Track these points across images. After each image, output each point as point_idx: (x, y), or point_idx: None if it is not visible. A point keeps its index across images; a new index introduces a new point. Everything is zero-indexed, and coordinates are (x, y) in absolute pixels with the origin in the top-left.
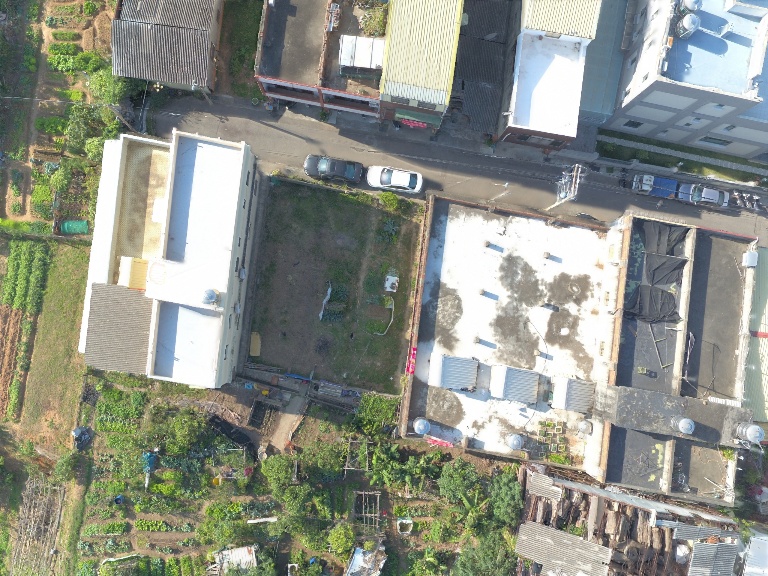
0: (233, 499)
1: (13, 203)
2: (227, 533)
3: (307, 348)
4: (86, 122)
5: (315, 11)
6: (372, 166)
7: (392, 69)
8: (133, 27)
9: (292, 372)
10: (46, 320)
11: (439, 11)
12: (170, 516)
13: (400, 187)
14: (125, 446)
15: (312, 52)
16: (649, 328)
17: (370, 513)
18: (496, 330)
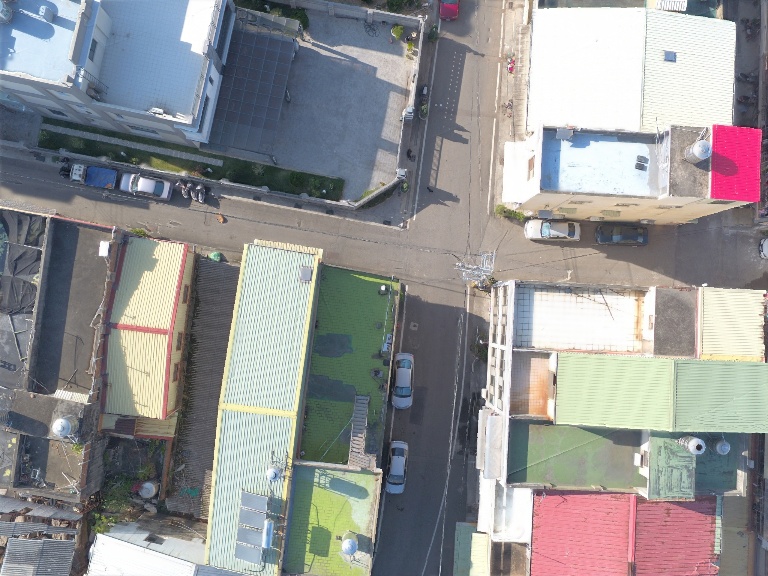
0: None
1: None
2: None
3: None
4: None
5: None
6: None
7: None
8: None
9: None
10: None
11: None
12: None
13: None
14: None
15: None
16: (9, 320)
17: None
18: None
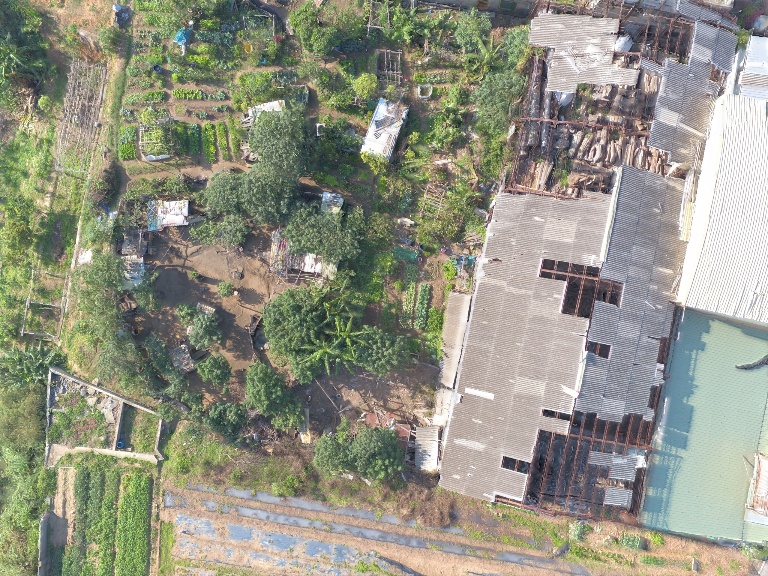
0: (264, 69)
1: None
2: (259, 81)
3: None
4: None
5: None
6: None
7: None
8: None
9: None
10: None
11: None
12: (205, 86)
13: None
14: (163, 3)
15: None
16: None
17: (392, 70)
18: None
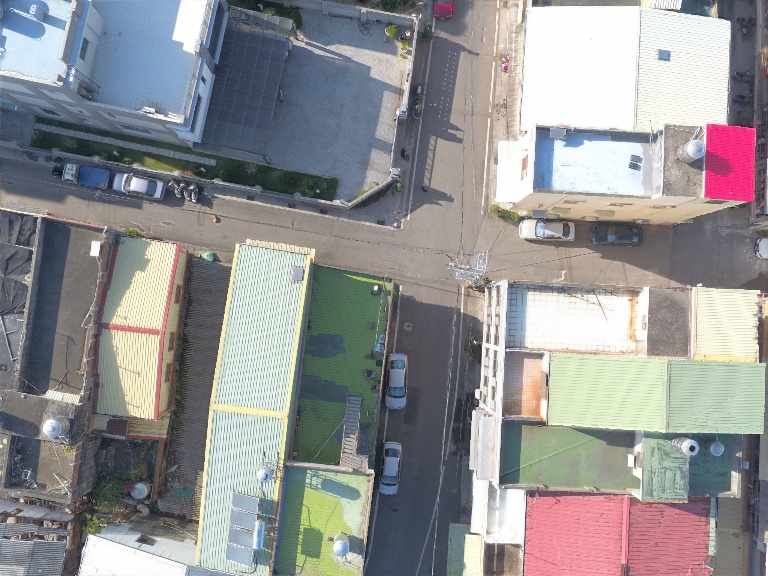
0: None
1: None
2: None
3: None
4: None
5: None
6: None
7: None
8: None
9: None
10: None
11: None
12: None
13: None
14: None
15: None
16: (0, 320)
17: None
18: None
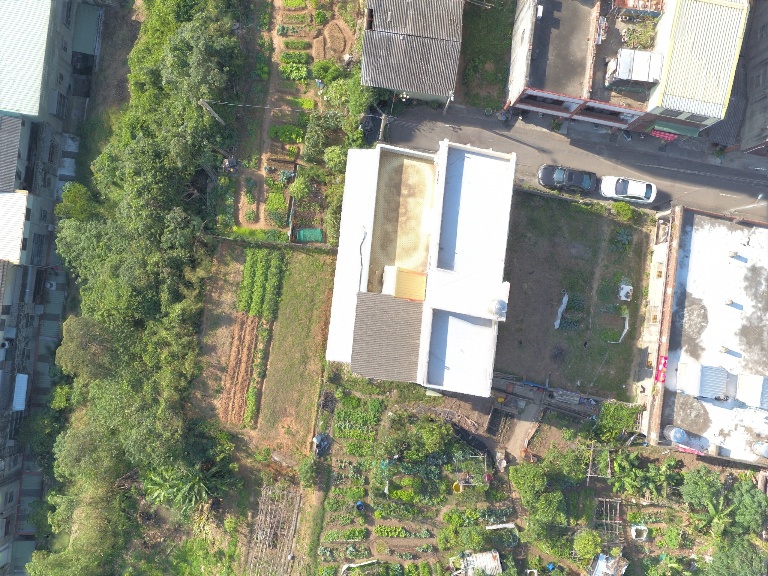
0: None
1: (247, 211)
2: (476, 539)
3: (542, 356)
4: (322, 131)
5: (578, 24)
6: (606, 176)
7: (671, 83)
8: (385, 37)
9: (527, 380)
10: (282, 327)
11: (723, 26)
12: (408, 522)
13: (635, 197)
14: (376, 453)
15: (576, 64)
16: None
17: (610, 520)
18: (741, 339)
